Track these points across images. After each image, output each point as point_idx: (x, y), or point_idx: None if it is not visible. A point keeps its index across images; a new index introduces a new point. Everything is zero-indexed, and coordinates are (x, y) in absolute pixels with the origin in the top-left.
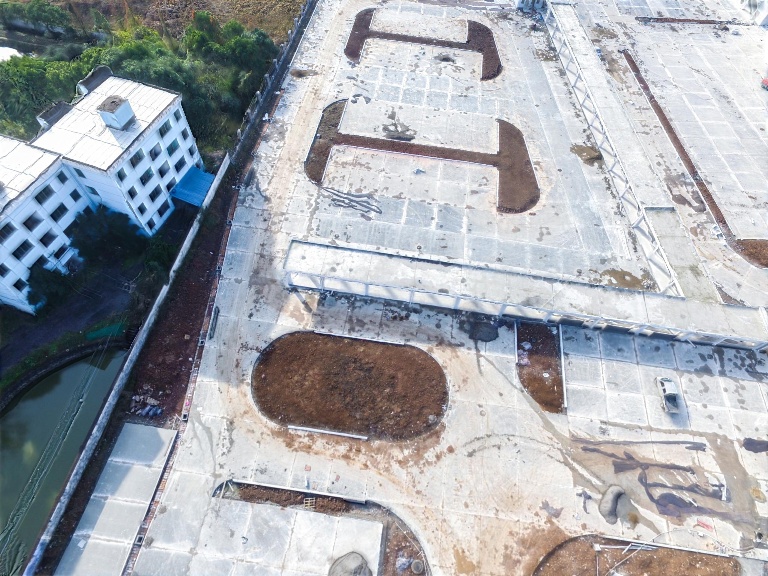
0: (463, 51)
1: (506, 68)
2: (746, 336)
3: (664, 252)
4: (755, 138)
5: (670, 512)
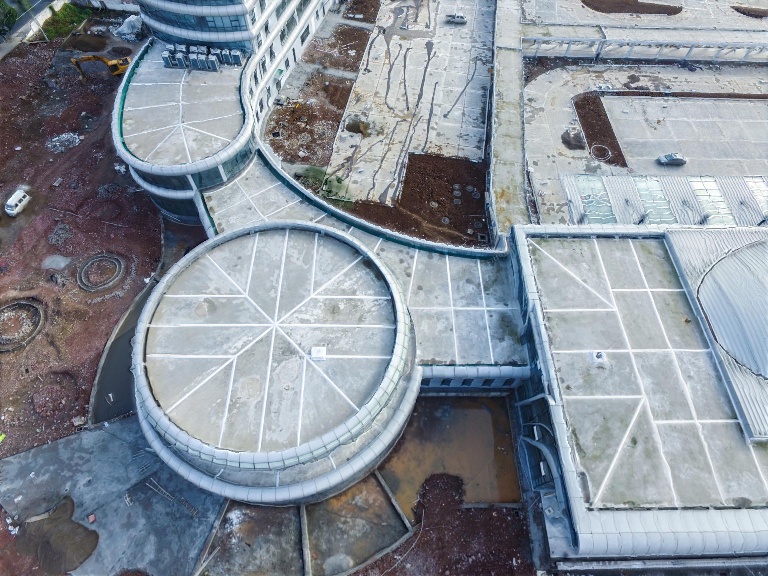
0: (767, 1)
1: (761, 20)
2: (498, 40)
3: (559, 25)
4: (762, 154)
5: (395, 10)
